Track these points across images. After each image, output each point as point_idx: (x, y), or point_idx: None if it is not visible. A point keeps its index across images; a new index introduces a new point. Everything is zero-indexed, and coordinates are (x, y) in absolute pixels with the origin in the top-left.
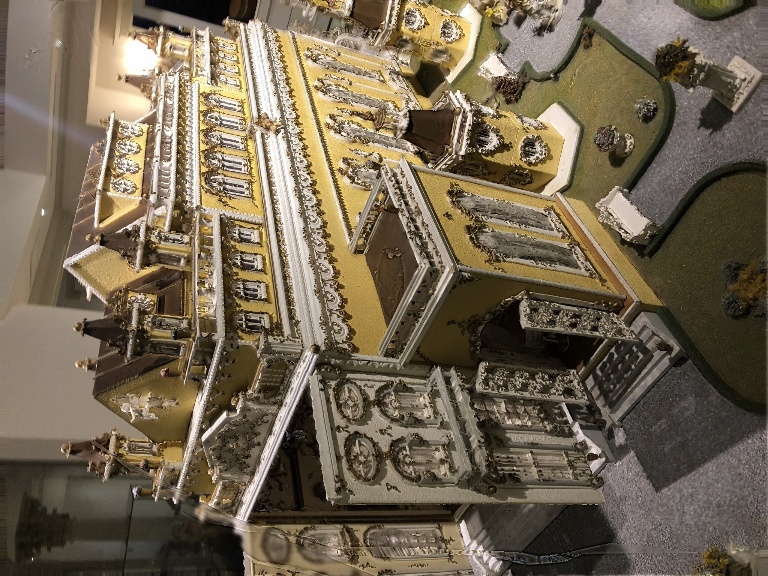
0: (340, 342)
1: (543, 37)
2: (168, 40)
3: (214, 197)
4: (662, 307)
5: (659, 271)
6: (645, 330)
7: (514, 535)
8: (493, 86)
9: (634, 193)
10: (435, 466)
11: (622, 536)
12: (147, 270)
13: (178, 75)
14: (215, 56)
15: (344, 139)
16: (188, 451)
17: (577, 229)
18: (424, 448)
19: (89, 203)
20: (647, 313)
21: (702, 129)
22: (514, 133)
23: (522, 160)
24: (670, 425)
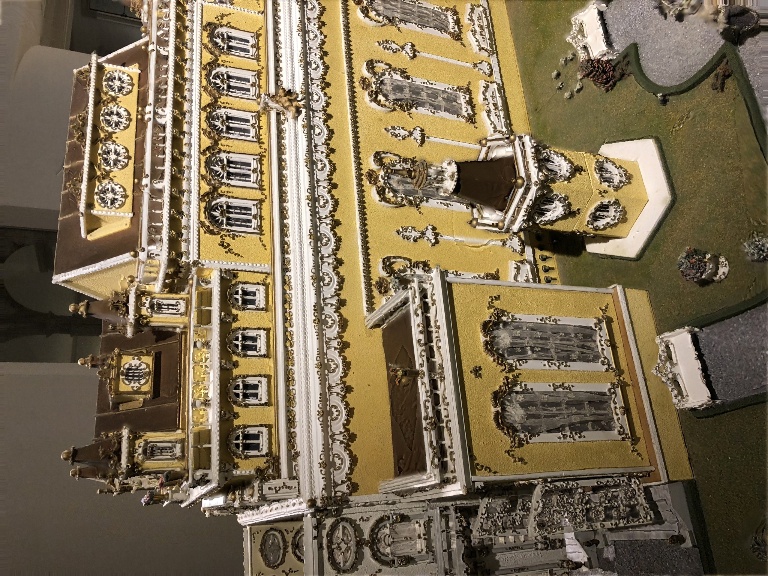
0: (339, 483)
1: (665, 20)
2: None
3: (215, 238)
4: (691, 481)
5: (701, 439)
6: (664, 501)
7: None
8: (581, 71)
9: (706, 332)
10: None
11: None
12: None
13: None
14: None
15: (381, 109)
16: (189, 500)
17: (627, 349)
18: None
19: None
20: (672, 484)
21: None
22: (586, 198)
23: (588, 226)
24: None
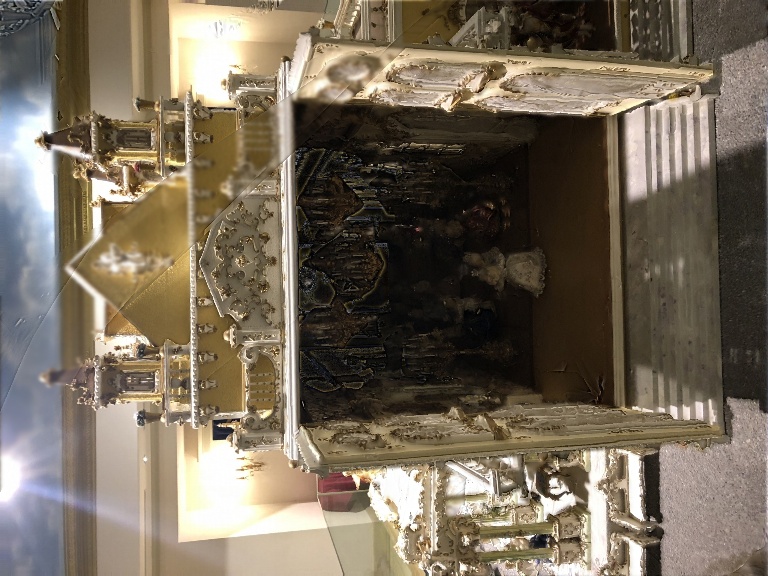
0: None
1: None
2: None
3: None
4: None
5: None
6: None
7: (694, 336)
8: None
9: None
10: (455, 69)
11: None
12: None
13: None
14: None
15: None
16: None
17: None
18: None
19: None
20: None
21: None
22: None
23: None
24: None
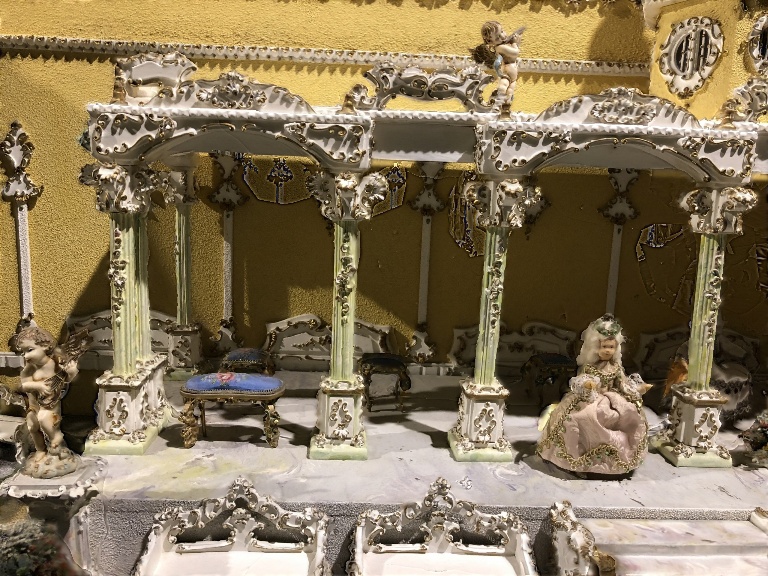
0: None
1: None
2: None
3: None
4: None
5: None
6: None
7: None
8: None
9: None
10: None
11: None
12: None
13: None
14: None
15: None
16: None
17: None
18: None
19: None
20: None
21: None
22: None
23: None
24: None
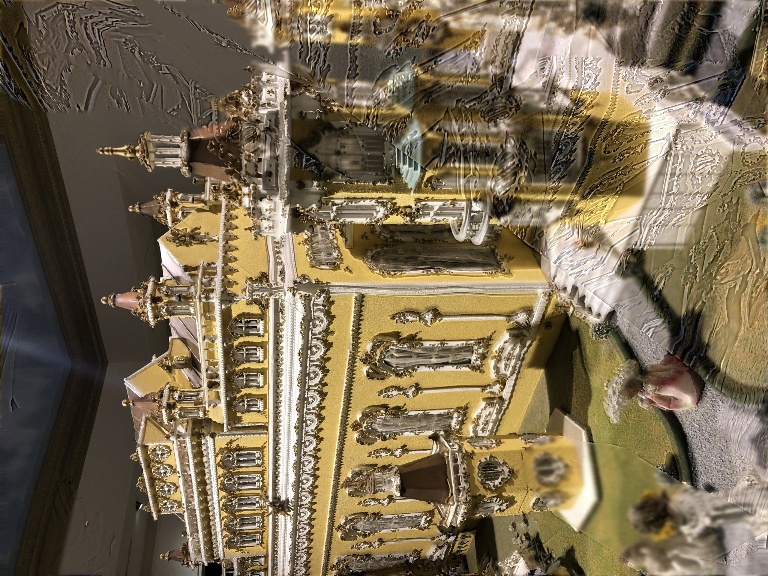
0: None
1: None
2: None
3: (233, 549)
4: None
5: None
6: None
7: None
8: None
9: None
10: None
11: None
12: None
13: (189, 442)
14: None
15: None
16: None
17: None
18: None
19: None
20: None
21: None
22: None
23: None
24: None
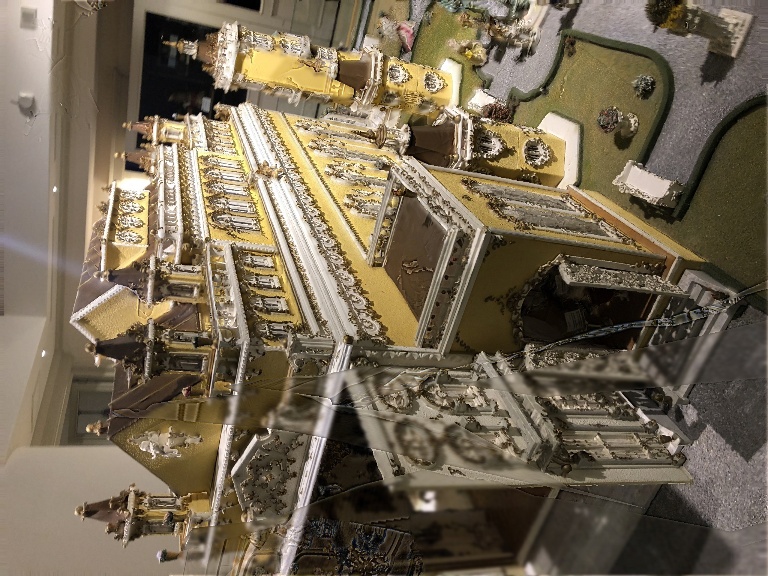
0: (373, 335)
1: (525, 62)
2: (163, 125)
3: (223, 232)
4: (705, 263)
5: (693, 230)
6: (693, 287)
7: None
8: (485, 113)
9: (649, 166)
10: None
11: (718, 525)
12: (158, 312)
13: (176, 144)
14: (210, 133)
15: (345, 182)
16: (217, 493)
17: (598, 211)
18: (482, 433)
19: (93, 271)
20: (691, 271)
21: (706, 84)
22: (515, 137)
23: (528, 163)
24: (744, 382)
